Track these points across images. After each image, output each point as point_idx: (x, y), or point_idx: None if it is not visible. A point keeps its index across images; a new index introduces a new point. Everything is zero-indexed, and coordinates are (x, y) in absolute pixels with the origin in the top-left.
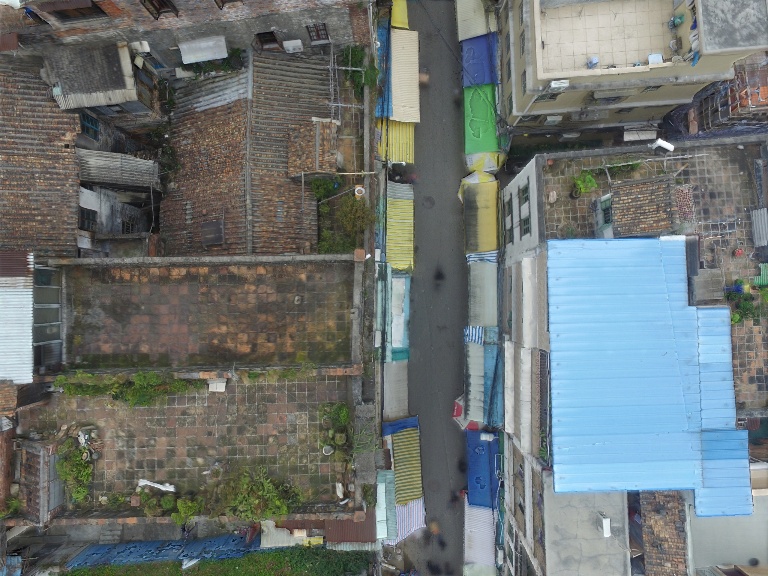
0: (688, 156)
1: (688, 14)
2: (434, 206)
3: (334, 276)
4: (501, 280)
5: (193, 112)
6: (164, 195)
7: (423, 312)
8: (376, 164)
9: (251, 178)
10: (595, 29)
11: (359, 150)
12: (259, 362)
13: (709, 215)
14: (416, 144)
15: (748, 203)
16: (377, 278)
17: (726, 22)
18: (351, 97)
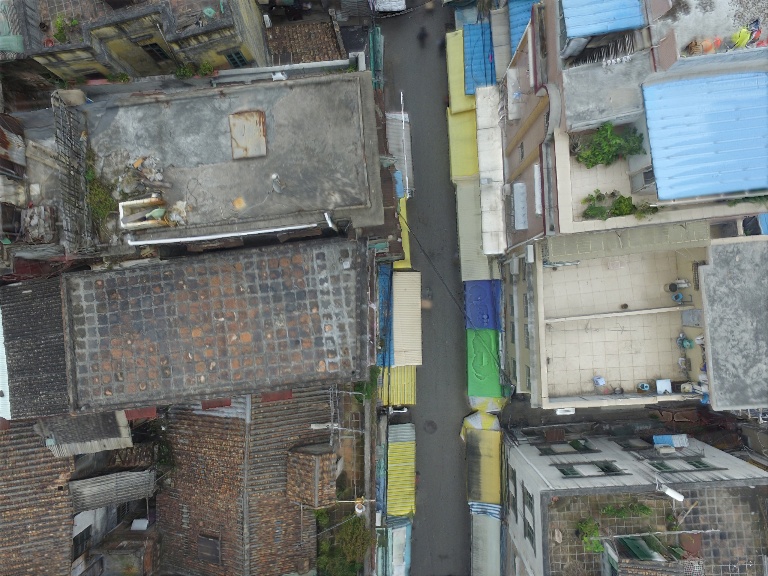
0: (698, 531)
1: (697, 345)
2: (436, 431)
3: None
4: (504, 543)
5: (190, 413)
6: (160, 488)
7: (424, 541)
8: (377, 451)
9: (249, 505)
10: (602, 343)
11: (360, 451)
12: None
13: (719, 556)
14: (418, 366)
15: (760, 544)
16: (378, 546)
17: (737, 377)
18: (352, 396)
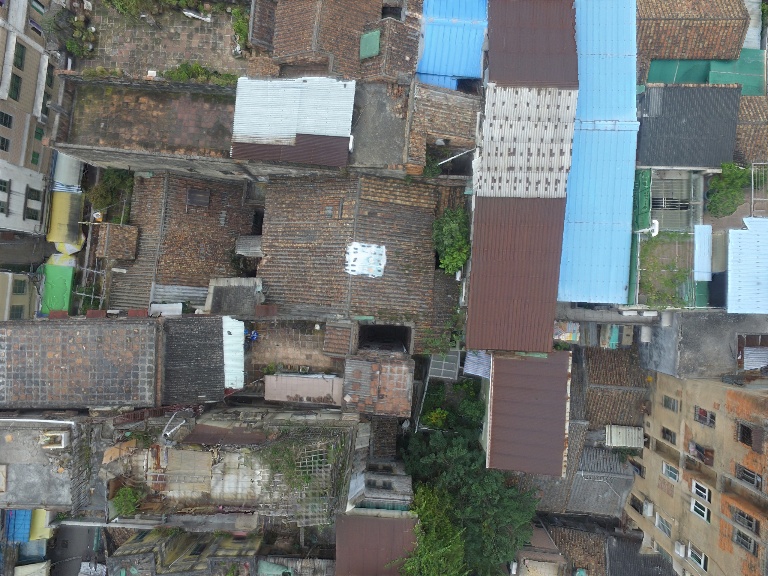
0: None
1: None
2: None
3: (82, 140)
4: (50, 167)
5: None
6: None
7: None
8: None
9: None
10: None
11: None
12: (135, 91)
13: None
14: None
15: None
16: None
17: None
18: None
